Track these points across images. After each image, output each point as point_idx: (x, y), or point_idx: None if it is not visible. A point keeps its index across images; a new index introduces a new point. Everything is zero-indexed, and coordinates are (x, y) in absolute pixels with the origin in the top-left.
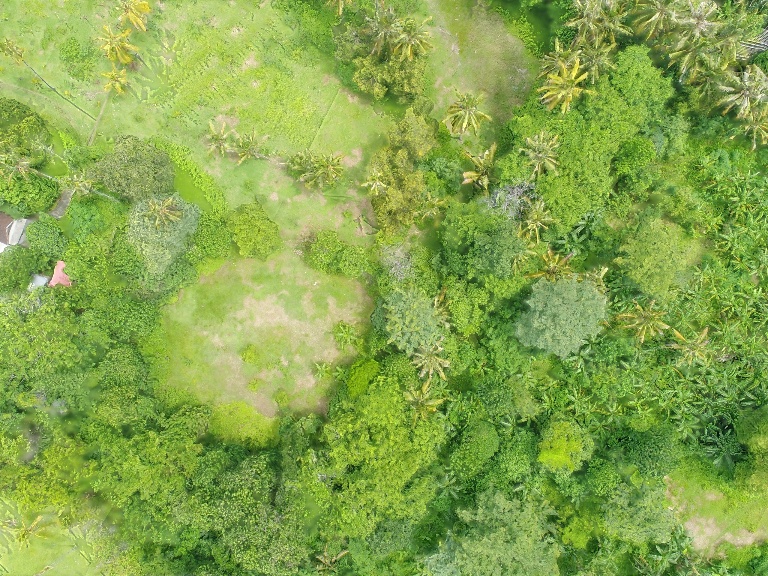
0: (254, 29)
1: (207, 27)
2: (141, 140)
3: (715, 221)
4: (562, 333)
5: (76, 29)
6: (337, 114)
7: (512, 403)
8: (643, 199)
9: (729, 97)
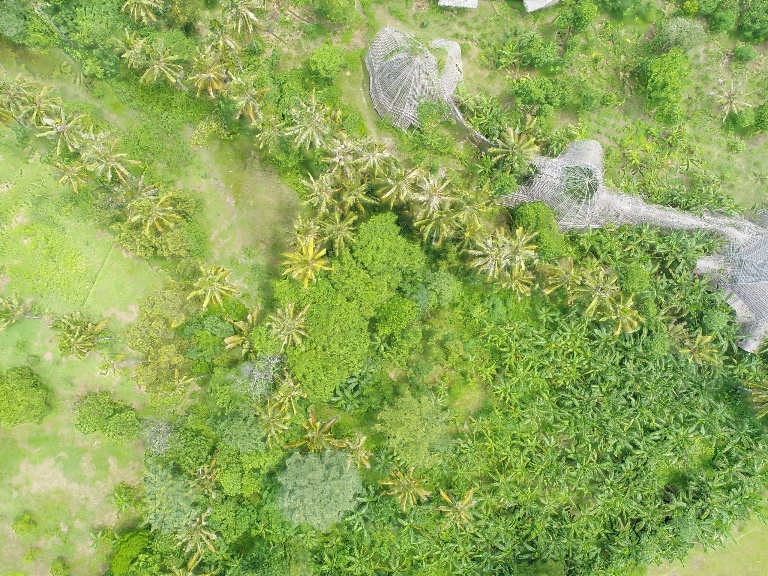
0: (23, 185)
1: None
2: None
3: (488, 371)
4: (312, 513)
5: None
6: (111, 270)
7: (289, 569)
8: (418, 350)
9: (479, 260)
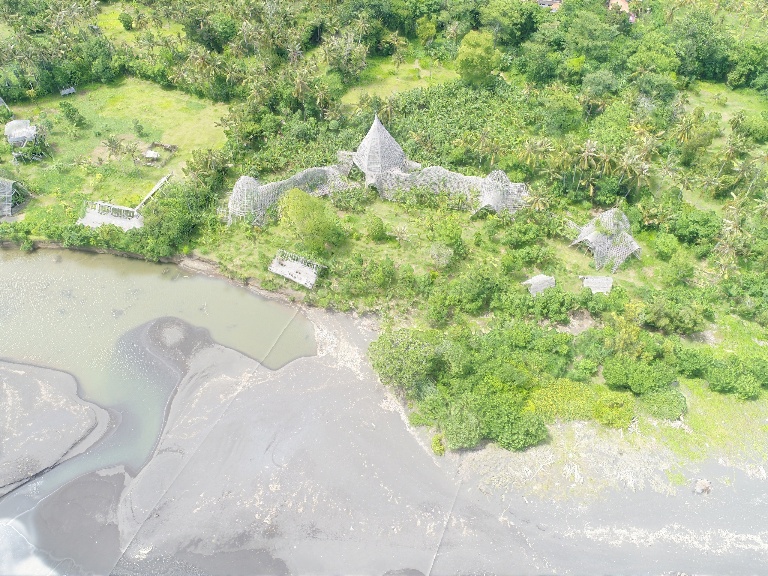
0: None
1: None
2: None
3: None
4: None
5: None
6: None
7: None
8: None
9: None
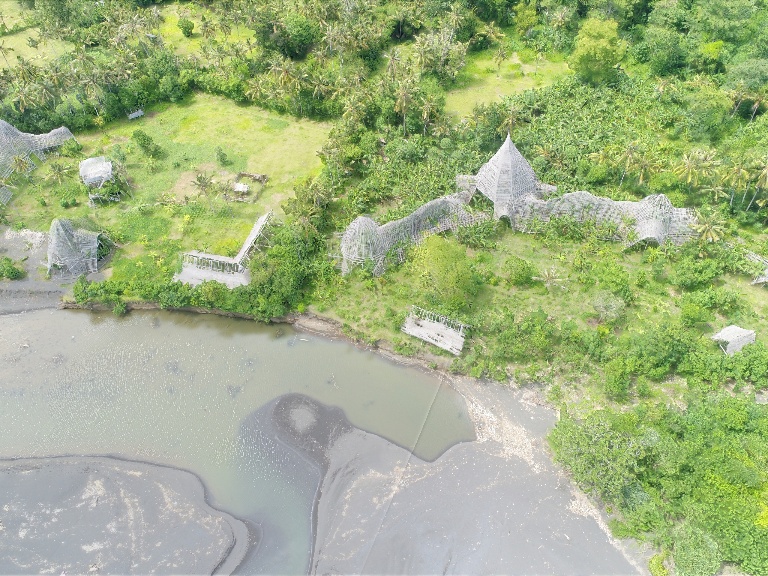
0: None
1: None
2: None
3: None
4: None
5: None
6: None
7: None
8: None
9: None
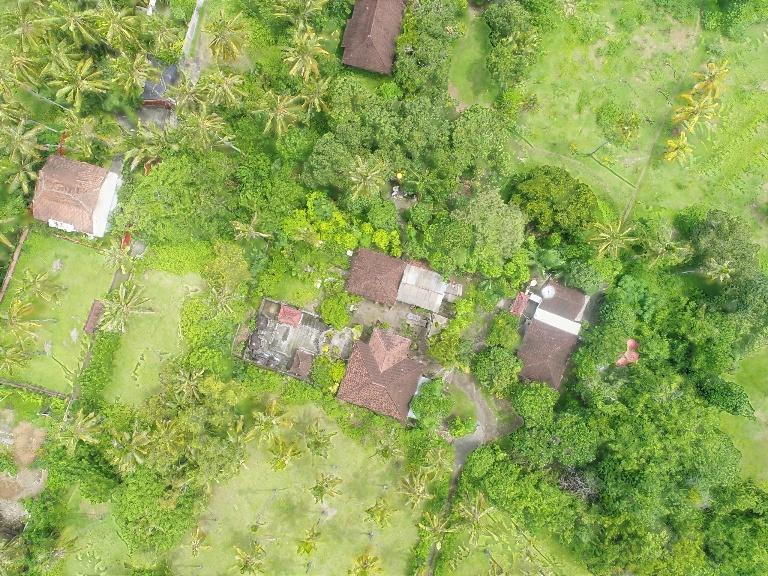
0: None
1: (756, 91)
2: (741, 216)
3: None
4: None
5: (615, 92)
6: None
7: None
8: None
9: None
